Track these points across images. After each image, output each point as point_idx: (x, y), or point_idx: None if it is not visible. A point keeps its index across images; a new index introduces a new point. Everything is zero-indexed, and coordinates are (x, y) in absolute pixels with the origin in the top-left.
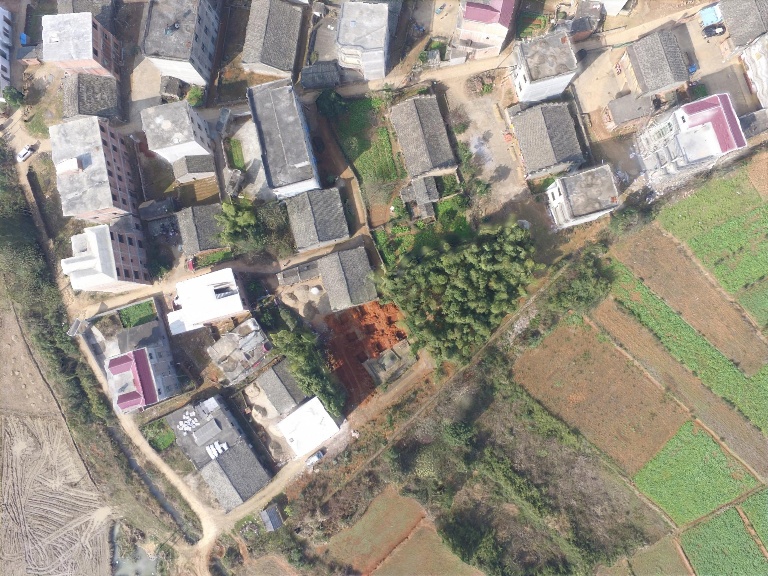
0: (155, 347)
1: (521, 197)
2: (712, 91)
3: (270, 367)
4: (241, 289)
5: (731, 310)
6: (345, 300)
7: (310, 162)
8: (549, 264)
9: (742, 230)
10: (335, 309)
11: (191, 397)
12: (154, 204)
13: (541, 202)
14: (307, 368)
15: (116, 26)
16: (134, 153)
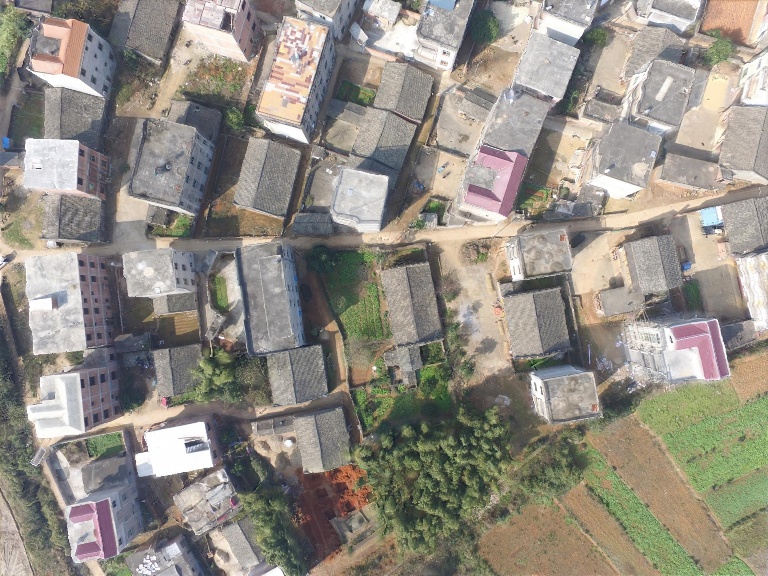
0: (120, 486)
1: (504, 372)
2: (705, 287)
3: (236, 522)
4: (213, 440)
5: (697, 507)
6: (317, 465)
7: (294, 330)
8: (525, 443)
9: (717, 431)
10: (307, 471)
11: (154, 534)
12: (131, 338)
13: (524, 380)
14: (272, 540)
15: (106, 140)
16: (114, 277)
